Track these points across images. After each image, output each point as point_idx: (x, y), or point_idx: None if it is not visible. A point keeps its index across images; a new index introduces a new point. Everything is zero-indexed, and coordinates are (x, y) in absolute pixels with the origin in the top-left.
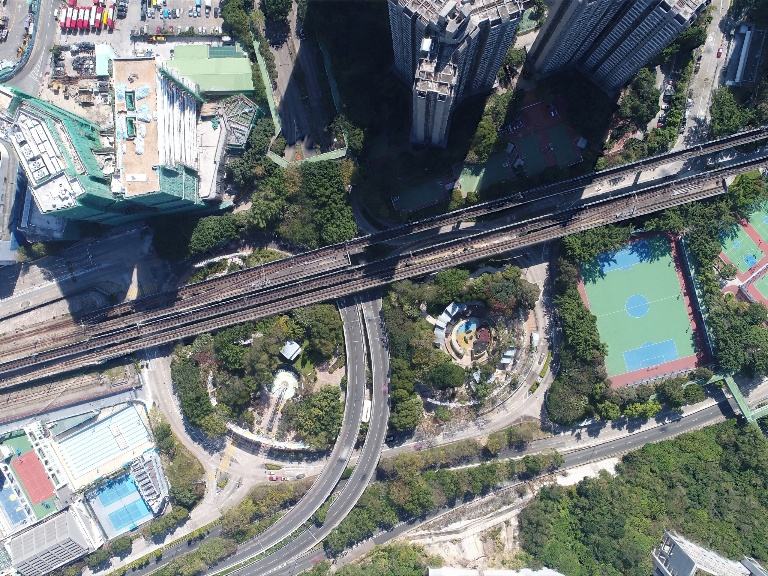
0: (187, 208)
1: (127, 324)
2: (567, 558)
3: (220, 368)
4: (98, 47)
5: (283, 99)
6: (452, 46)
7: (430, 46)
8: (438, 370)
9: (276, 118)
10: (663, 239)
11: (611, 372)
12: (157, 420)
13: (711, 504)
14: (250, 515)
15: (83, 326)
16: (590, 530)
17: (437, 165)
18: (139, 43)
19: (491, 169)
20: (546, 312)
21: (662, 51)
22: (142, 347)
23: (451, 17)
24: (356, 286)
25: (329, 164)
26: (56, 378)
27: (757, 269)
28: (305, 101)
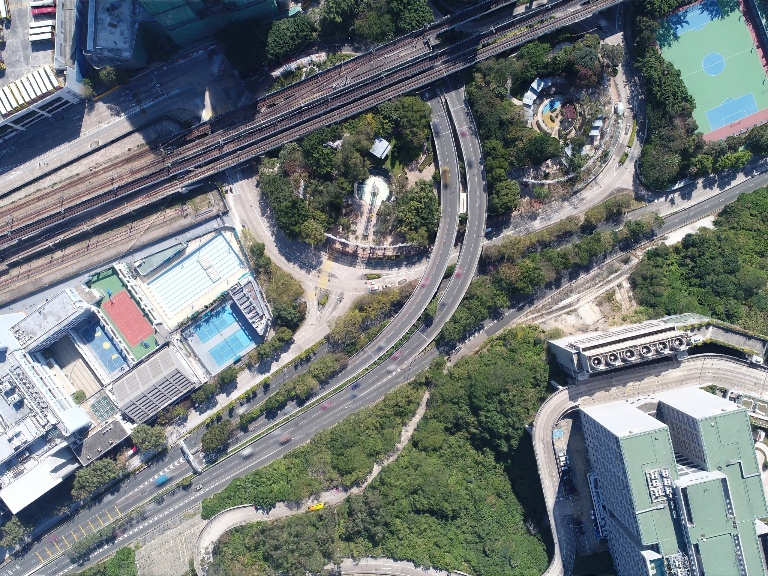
0: (260, 10)
1: (208, 145)
2: (687, 301)
3: (310, 177)
4: None
5: None
6: None
7: None
8: (533, 143)
9: None
10: None
11: None
12: None
13: None
14: (355, 329)
15: (163, 151)
16: (705, 272)
17: None
18: None
19: None
20: (626, 82)
21: None
22: (226, 166)
23: None
24: (439, 73)
25: None
26: (137, 216)
27: None
28: None
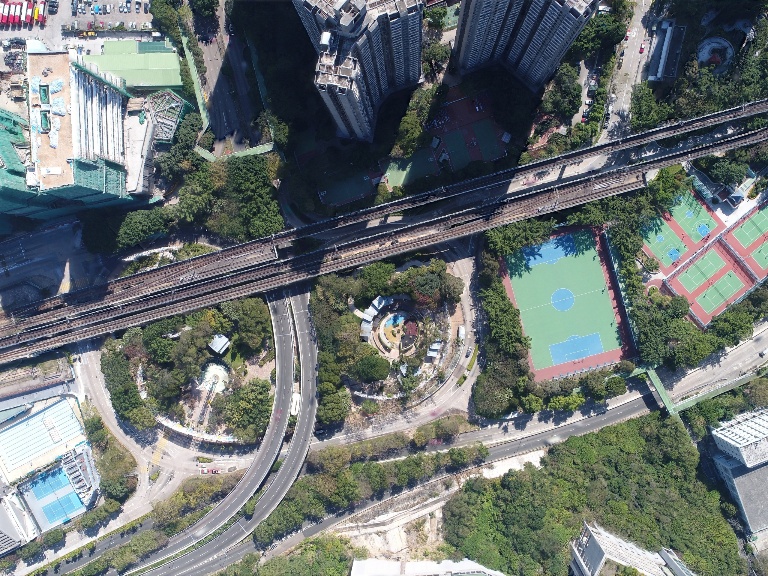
0: (115, 202)
1: (58, 318)
2: (487, 549)
3: (150, 361)
4: (29, 42)
5: (212, 94)
6: (351, 40)
7: (329, 39)
8: (363, 363)
9: (204, 113)
10: (588, 233)
11: (537, 365)
12: (90, 413)
13: (632, 496)
14: (182, 508)
15: (14, 320)
16: (510, 522)
17: (362, 159)
18: (70, 38)
19: (417, 164)
20: (473, 306)
21: (582, 46)
22: (73, 341)
23: (348, 11)
24: (283, 280)
25: (255, 158)
26: None
27: (681, 263)
28: (234, 96)
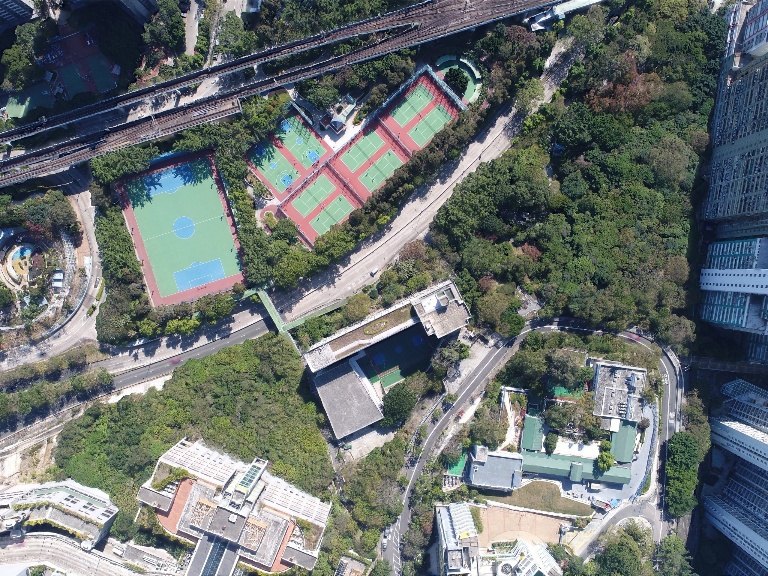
0: None
1: None
2: (87, 468)
3: None
4: None
5: None
6: None
7: None
8: None
9: None
10: (204, 162)
11: (163, 293)
12: None
13: (237, 412)
14: None
15: None
16: (111, 440)
17: None
18: None
19: (36, 98)
20: None
21: None
22: None
23: None
24: None
25: None
26: None
27: (294, 189)
28: None
